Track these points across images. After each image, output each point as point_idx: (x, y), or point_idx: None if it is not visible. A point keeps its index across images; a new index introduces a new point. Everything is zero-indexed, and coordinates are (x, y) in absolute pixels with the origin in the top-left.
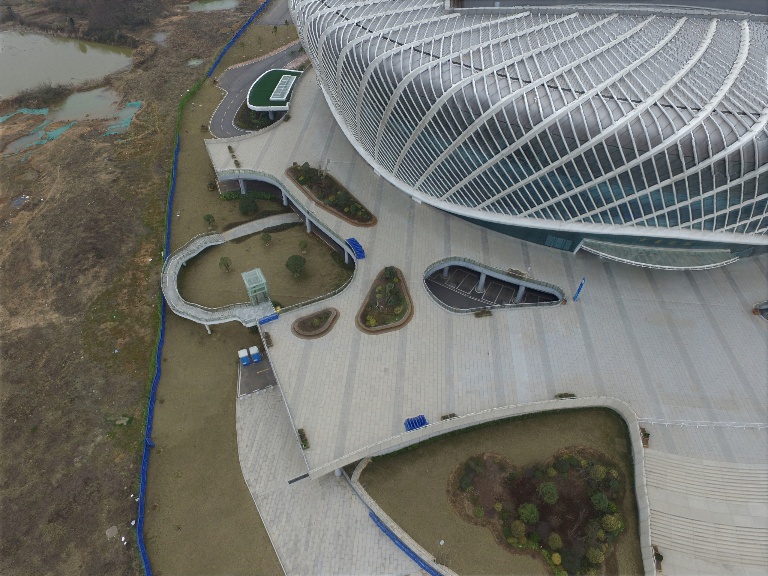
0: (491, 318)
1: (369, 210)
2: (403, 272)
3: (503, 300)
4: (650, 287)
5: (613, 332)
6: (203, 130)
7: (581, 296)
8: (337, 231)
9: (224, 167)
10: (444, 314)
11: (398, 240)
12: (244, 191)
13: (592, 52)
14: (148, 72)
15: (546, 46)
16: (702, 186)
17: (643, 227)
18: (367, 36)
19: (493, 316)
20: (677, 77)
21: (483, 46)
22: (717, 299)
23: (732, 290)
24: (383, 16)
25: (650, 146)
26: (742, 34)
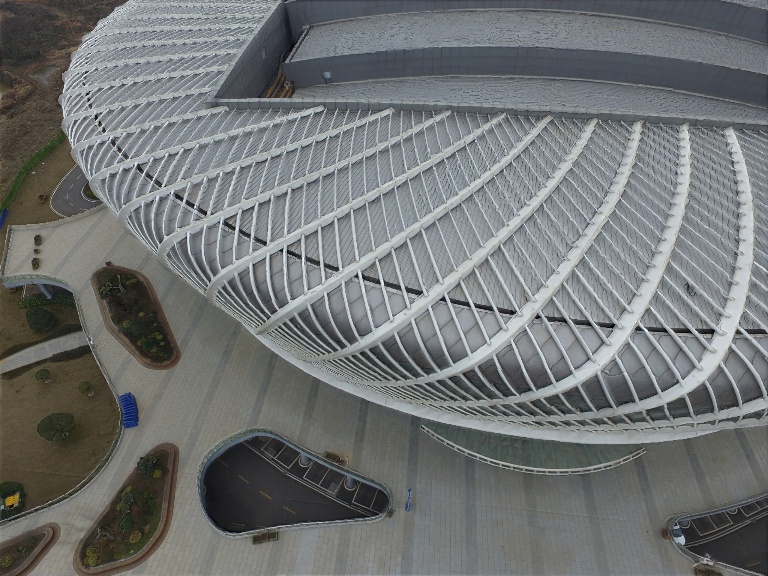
0: (275, 545)
1: (176, 340)
2: (180, 453)
3: (332, 480)
4: (522, 482)
5: (447, 575)
6: (40, 201)
7: (419, 500)
8: (118, 377)
9: (18, 268)
10: (210, 536)
11: (195, 393)
12: (49, 295)
13: (377, 188)
14: (11, 120)
15: (313, 175)
16: (543, 410)
17: (492, 422)
18: (93, 140)
19: (279, 541)
20: (489, 246)
21: (226, 170)
22: (614, 506)
23: (639, 488)
24: (129, 106)
25: (437, 367)
26: (626, 150)
